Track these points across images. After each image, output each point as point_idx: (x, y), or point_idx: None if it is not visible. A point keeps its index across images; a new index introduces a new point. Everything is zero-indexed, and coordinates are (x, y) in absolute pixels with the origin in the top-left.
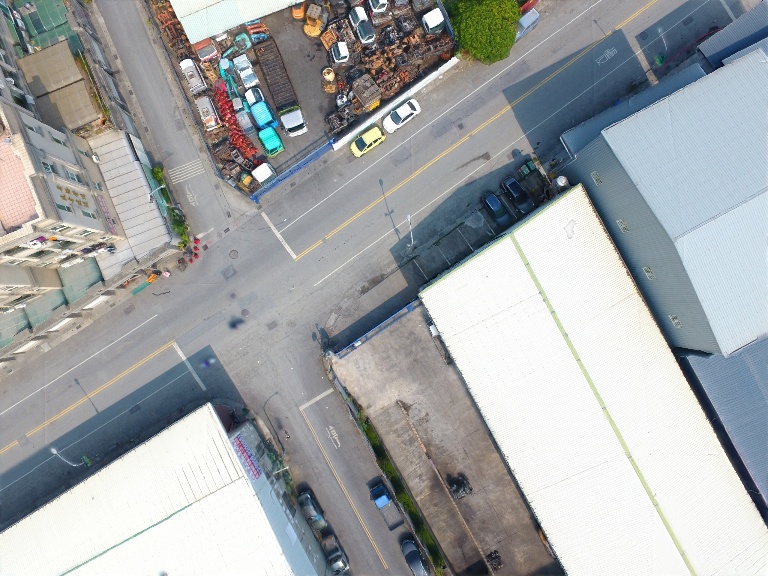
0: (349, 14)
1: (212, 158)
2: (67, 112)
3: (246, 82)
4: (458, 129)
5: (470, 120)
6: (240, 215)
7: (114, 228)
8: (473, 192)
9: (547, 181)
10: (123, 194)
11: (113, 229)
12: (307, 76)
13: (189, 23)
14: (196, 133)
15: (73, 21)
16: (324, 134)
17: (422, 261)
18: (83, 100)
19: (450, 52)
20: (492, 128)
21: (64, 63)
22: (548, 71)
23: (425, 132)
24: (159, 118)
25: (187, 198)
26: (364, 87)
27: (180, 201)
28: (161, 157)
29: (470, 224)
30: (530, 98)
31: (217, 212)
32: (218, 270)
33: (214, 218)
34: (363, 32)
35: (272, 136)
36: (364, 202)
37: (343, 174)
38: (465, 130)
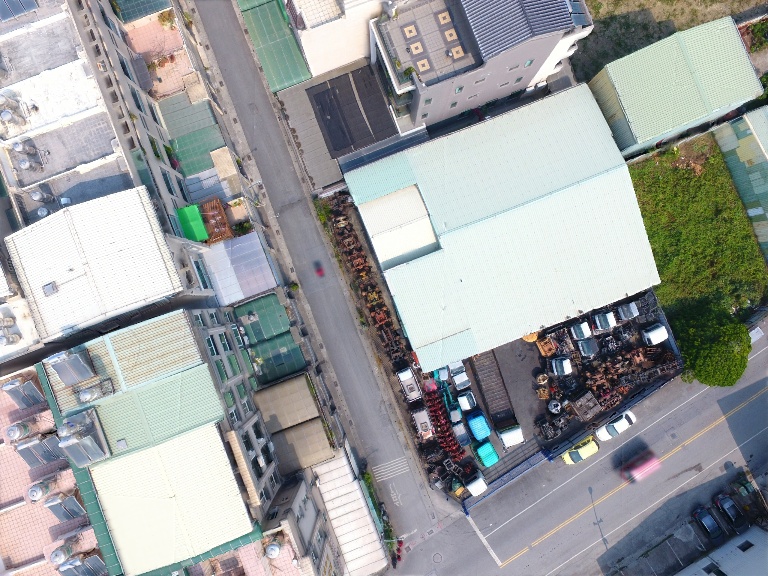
0: (571, 327)
1: (422, 463)
2: (304, 454)
3: (460, 386)
4: (671, 438)
5: (683, 430)
6: (444, 517)
7: (340, 564)
8: (683, 504)
9: (760, 497)
10: (342, 516)
11: (341, 568)
12: (518, 376)
13: (424, 354)
14: (402, 430)
15: (297, 336)
16: (533, 437)
17: (629, 573)
18: (321, 442)
19: (674, 372)
20: (705, 439)
21: (302, 403)
22: (764, 382)
23: (637, 440)
24: (364, 412)
25: (391, 497)
26: (587, 407)
27: (384, 500)
28: (365, 453)
29: (680, 537)
30: (745, 410)
31: (421, 513)
32: (421, 574)
33: (418, 519)
34: (586, 348)
35: (491, 453)
36: (572, 510)
37: (552, 479)
38: (678, 440)
